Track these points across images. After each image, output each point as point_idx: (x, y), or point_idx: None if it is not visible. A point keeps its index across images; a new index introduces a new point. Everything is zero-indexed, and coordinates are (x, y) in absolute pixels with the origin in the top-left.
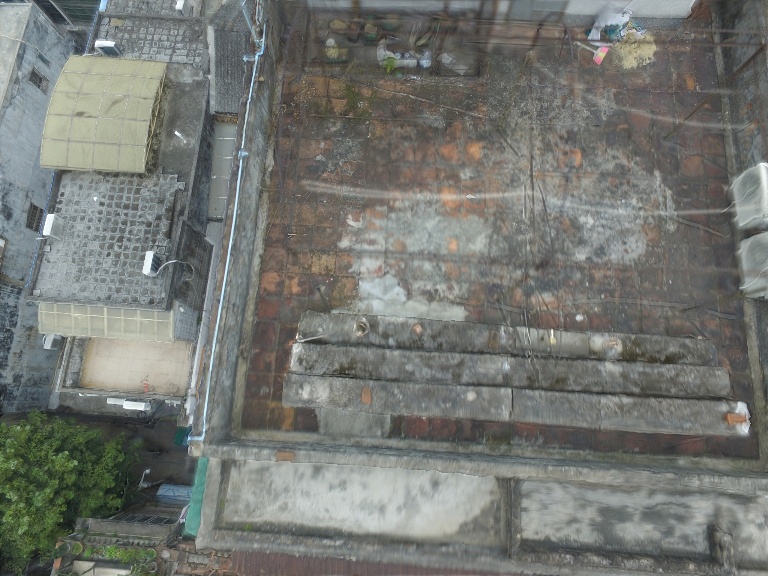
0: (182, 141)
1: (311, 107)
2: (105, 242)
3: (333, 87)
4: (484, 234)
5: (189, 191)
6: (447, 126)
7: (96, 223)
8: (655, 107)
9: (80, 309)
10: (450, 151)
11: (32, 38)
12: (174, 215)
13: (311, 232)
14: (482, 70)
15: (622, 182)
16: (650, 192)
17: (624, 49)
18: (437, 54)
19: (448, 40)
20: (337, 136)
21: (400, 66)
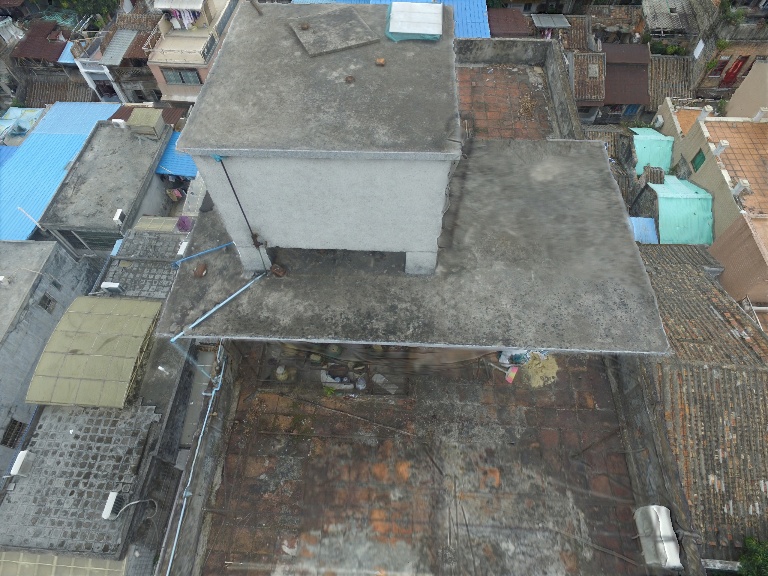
0: (165, 372)
1: (260, 424)
2: (71, 479)
3: (282, 404)
4: (411, 563)
5: (163, 424)
6: (379, 444)
7: (67, 458)
8: (562, 425)
9: (29, 556)
10: (382, 470)
11: (50, 269)
12: (145, 449)
13: (247, 560)
14: (410, 390)
15: (538, 504)
16: (564, 515)
17: (531, 368)
18: (373, 374)
19: (379, 370)
20: (281, 454)
21: (339, 388)
